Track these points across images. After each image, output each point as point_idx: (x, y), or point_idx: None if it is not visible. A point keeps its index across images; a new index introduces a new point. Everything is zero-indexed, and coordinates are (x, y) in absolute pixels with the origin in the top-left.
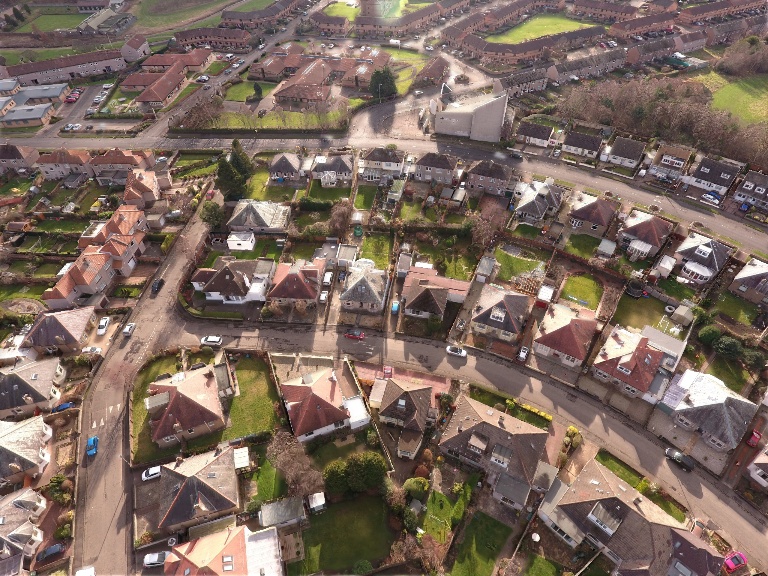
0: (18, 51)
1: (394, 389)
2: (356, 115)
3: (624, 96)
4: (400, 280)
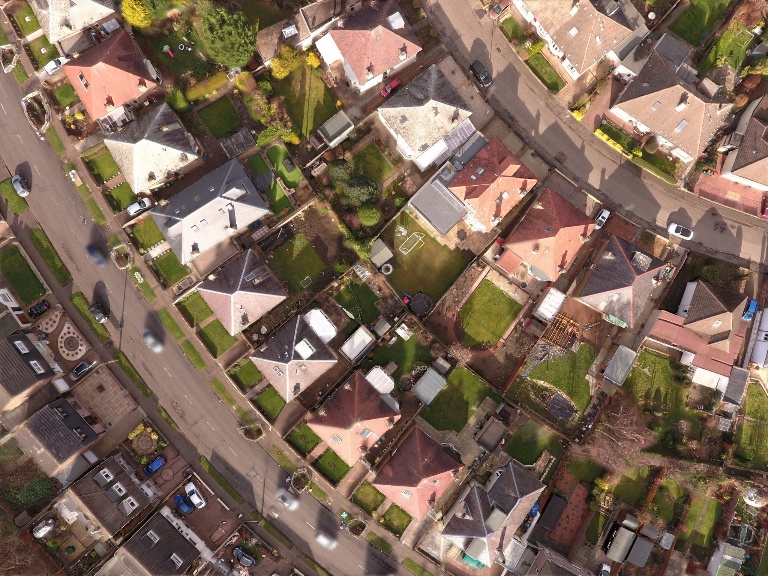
0: None
1: None
2: None
3: None
4: None
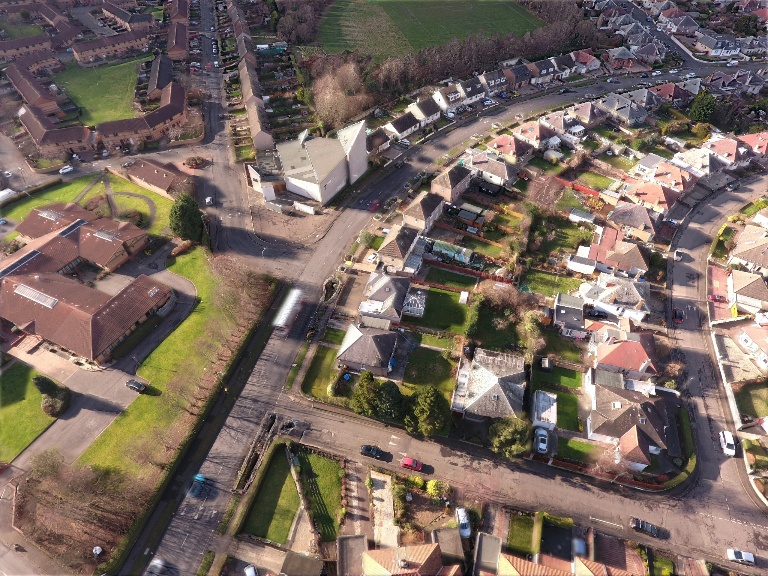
0: None
1: (753, 287)
2: None
3: (350, 82)
4: (596, 274)
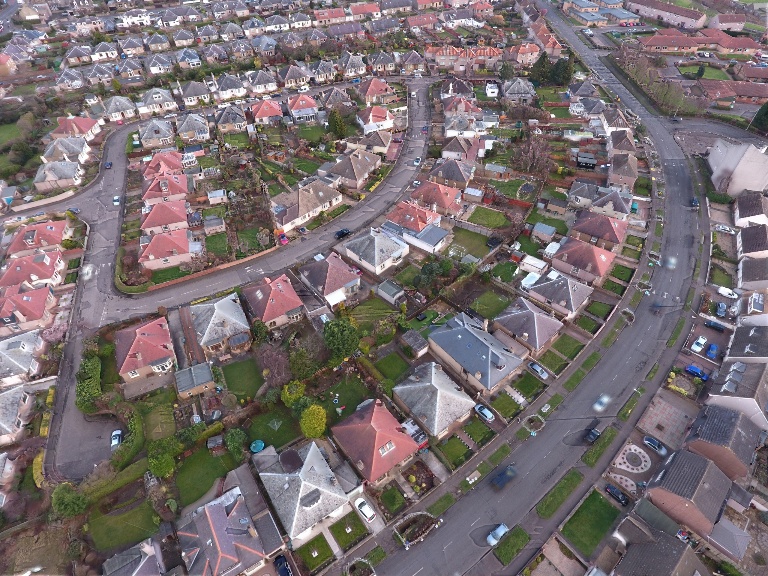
0: (686, 1)
1: None
2: (704, 119)
3: None
4: None
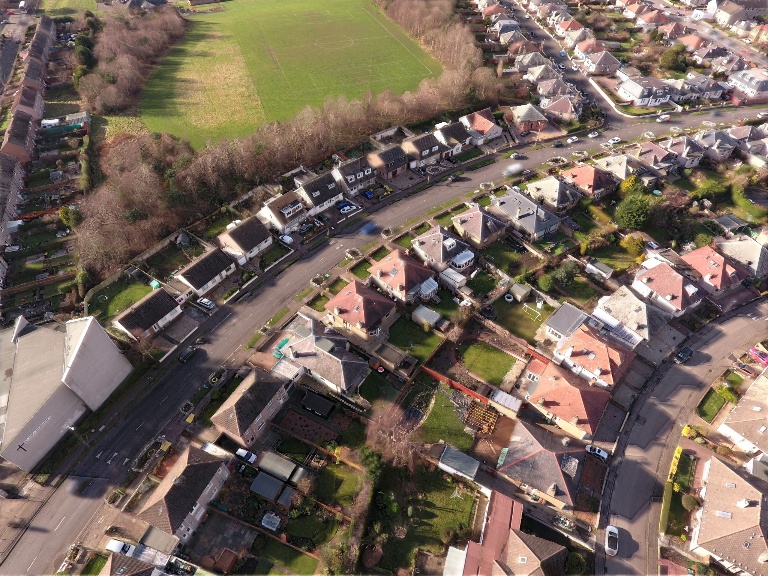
0: None
1: None
2: None
3: (138, 195)
4: None
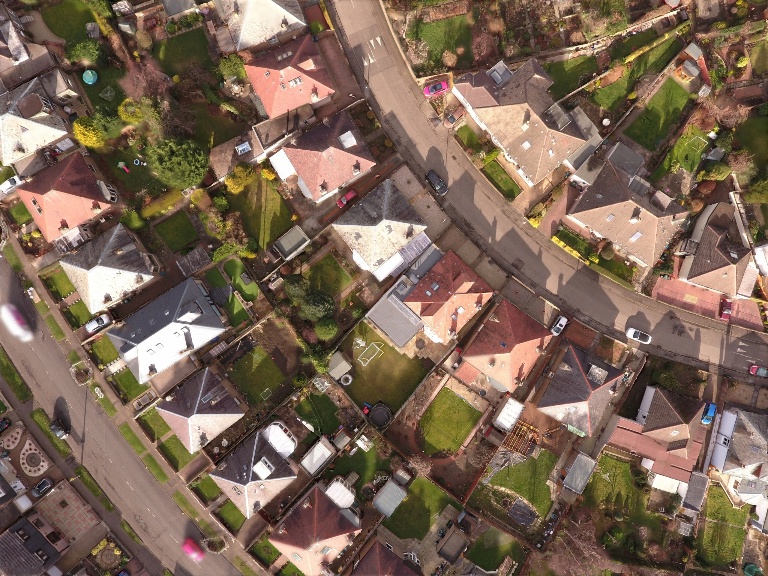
0: None
1: None
2: None
3: None
4: None
